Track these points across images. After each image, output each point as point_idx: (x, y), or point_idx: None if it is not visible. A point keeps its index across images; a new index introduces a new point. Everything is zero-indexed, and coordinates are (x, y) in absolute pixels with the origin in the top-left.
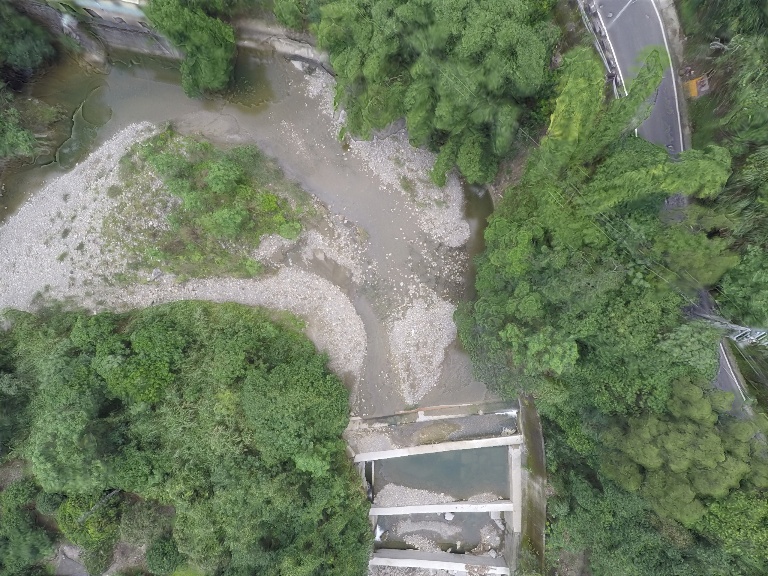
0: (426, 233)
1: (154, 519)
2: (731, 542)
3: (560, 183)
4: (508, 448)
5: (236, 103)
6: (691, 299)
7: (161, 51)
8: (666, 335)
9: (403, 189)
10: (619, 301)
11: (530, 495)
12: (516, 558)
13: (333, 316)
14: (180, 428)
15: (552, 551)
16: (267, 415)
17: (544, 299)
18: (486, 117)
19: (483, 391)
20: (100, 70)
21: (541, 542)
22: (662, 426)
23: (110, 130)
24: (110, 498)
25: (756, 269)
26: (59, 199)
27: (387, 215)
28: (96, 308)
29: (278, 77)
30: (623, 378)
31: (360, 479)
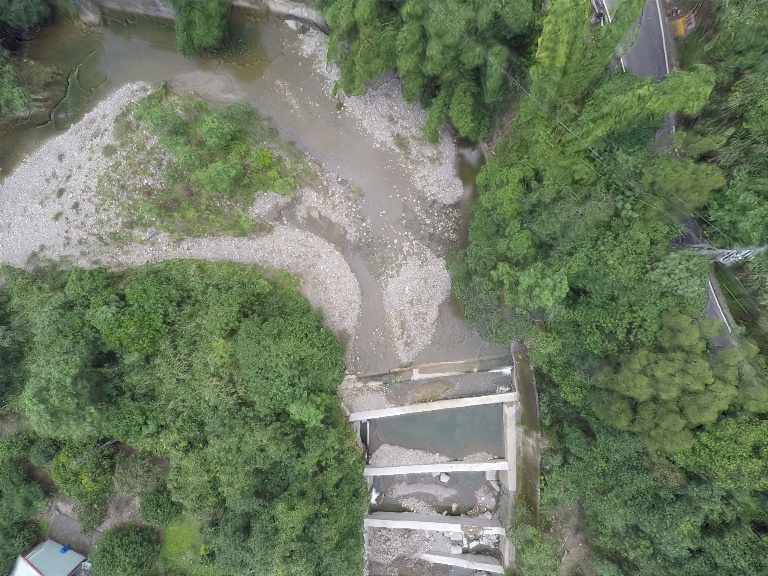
0: (420, 190)
1: (148, 469)
2: (721, 471)
3: (550, 122)
4: (503, 407)
5: (231, 63)
6: (679, 229)
7: (156, 7)
8: (655, 264)
9: (397, 146)
10: (608, 235)
11: (525, 452)
12: (511, 517)
13: (327, 274)
14: (174, 379)
15: (547, 505)
16: (261, 363)
17: (535, 237)
18: (476, 57)
19: (477, 348)
20: (95, 29)
21: (536, 497)
22: (652, 356)
23: (105, 91)
24: (104, 448)
25: (742, 193)
26: (54, 159)
27: (381, 173)
28: (91, 267)
29: (272, 37)
30: (613, 314)
31: (355, 435)
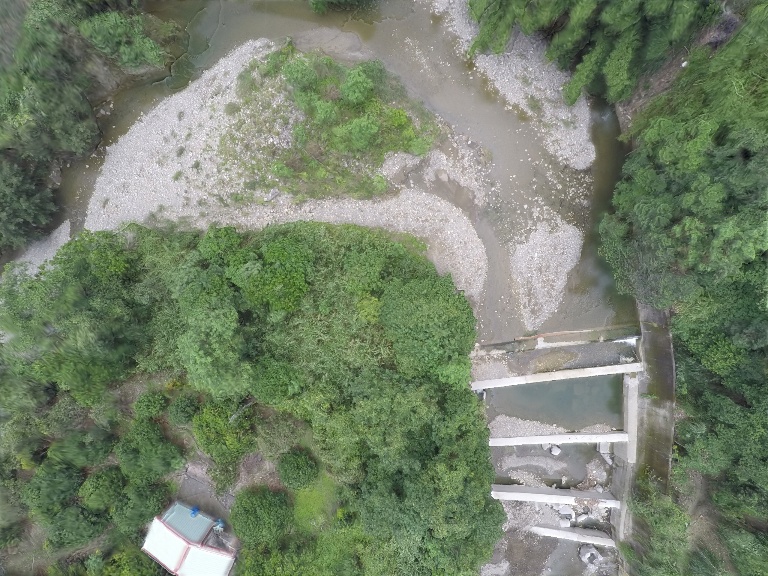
0: (552, 155)
1: (293, 431)
2: None
3: (741, 73)
4: (623, 378)
5: (357, 20)
6: None
7: None
8: None
9: (530, 109)
10: None
11: (651, 422)
12: (628, 490)
13: (455, 239)
14: (316, 340)
15: (679, 475)
16: (413, 323)
17: (724, 191)
18: (670, 3)
19: (604, 317)
20: None
21: (666, 467)
22: None
23: (225, 47)
24: (249, 408)
25: None
26: (172, 117)
27: (512, 136)
28: None
29: None
30: None
31: (485, 402)
